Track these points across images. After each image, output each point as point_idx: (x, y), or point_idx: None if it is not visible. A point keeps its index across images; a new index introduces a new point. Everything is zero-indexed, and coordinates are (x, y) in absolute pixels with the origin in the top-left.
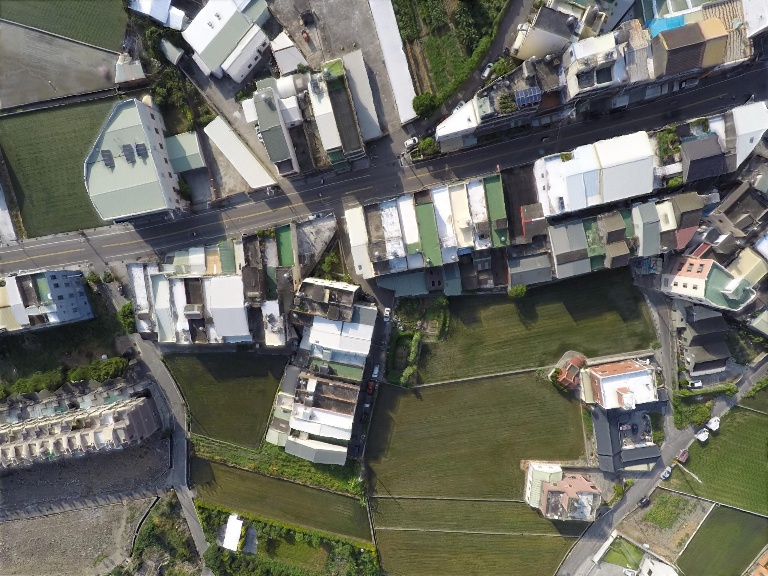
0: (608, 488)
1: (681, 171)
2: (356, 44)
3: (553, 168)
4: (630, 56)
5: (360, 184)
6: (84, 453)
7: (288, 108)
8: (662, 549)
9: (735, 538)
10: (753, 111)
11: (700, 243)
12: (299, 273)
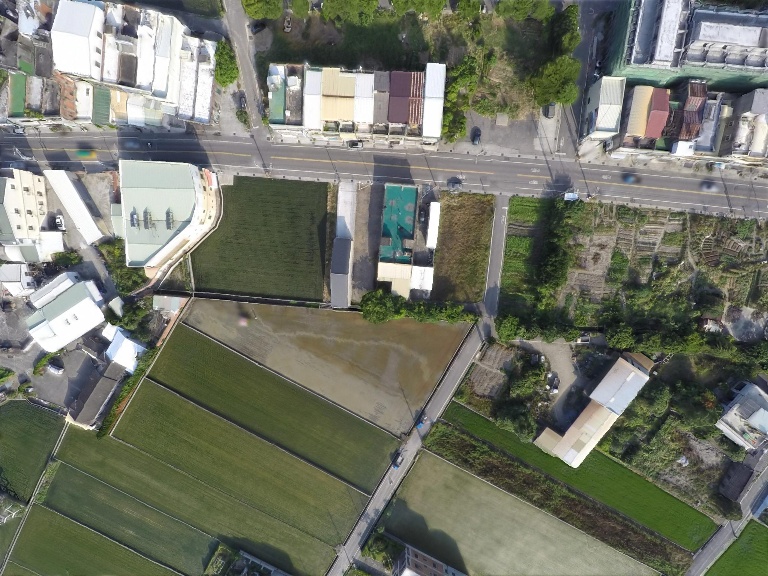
0: None
1: None
2: None
3: None
4: None
5: None
6: None
7: None
8: None
9: None
10: None
11: None
12: None
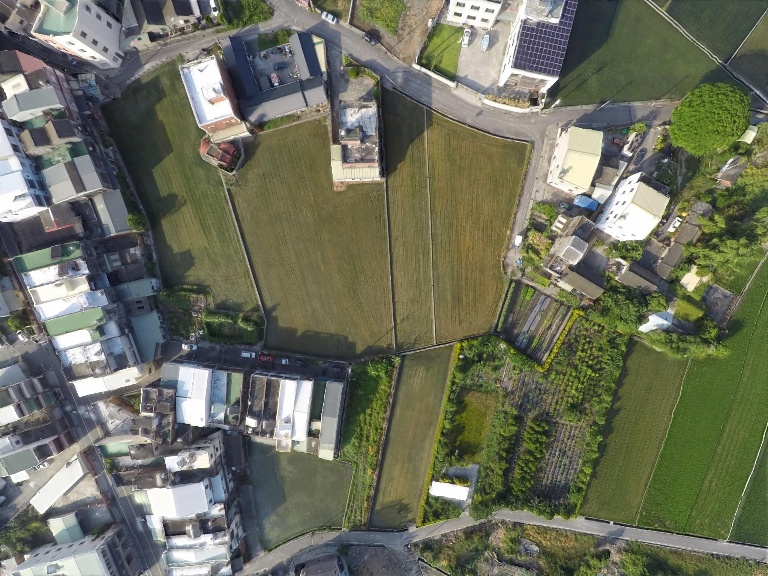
0: (358, 85)
1: None
2: None
3: None
4: None
5: None
6: None
7: None
8: (434, 1)
9: None
10: None
11: None
12: None
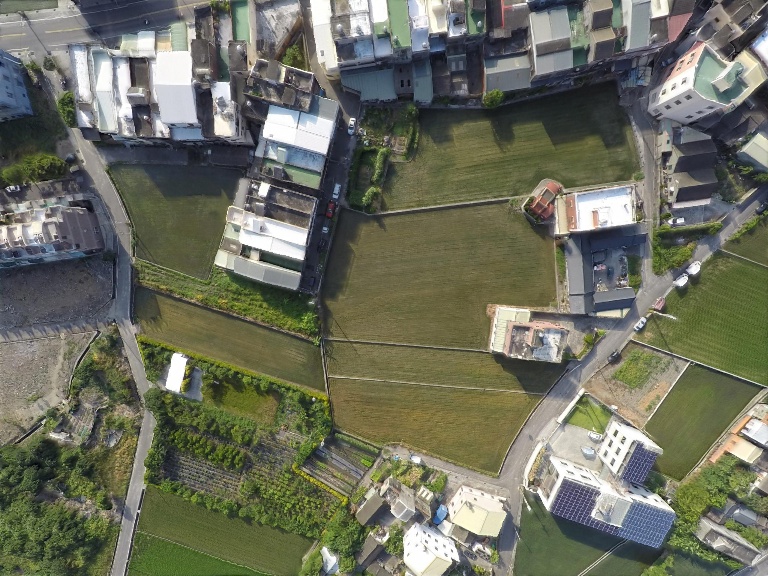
0: (578, 340)
1: None
2: None
3: None
4: None
5: None
6: (13, 256)
7: None
8: (631, 412)
9: (708, 403)
10: None
11: (693, 43)
12: None
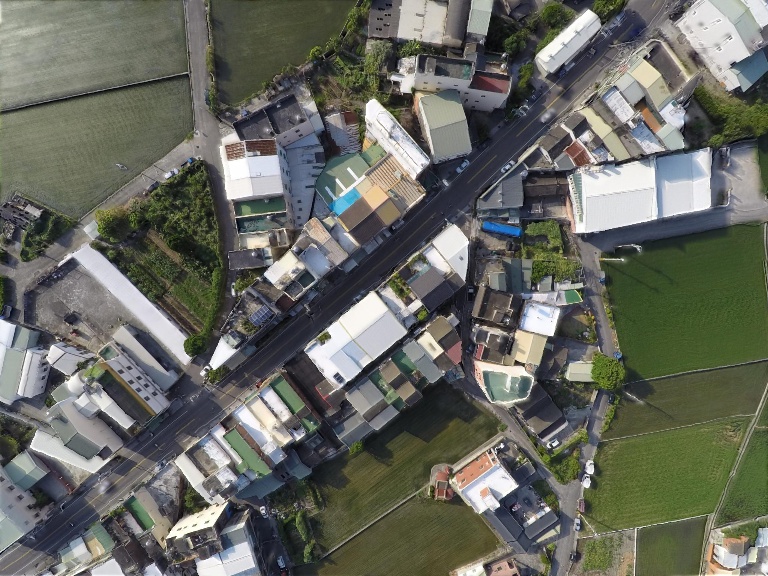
0: (537, 560)
1: (422, 305)
2: (120, 318)
3: (316, 355)
4: (322, 249)
5: (184, 421)
6: None
7: (83, 406)
8: None
9: (672, 548)
10: (449, 236)
11: (477, 345)
12: (167, 523)
